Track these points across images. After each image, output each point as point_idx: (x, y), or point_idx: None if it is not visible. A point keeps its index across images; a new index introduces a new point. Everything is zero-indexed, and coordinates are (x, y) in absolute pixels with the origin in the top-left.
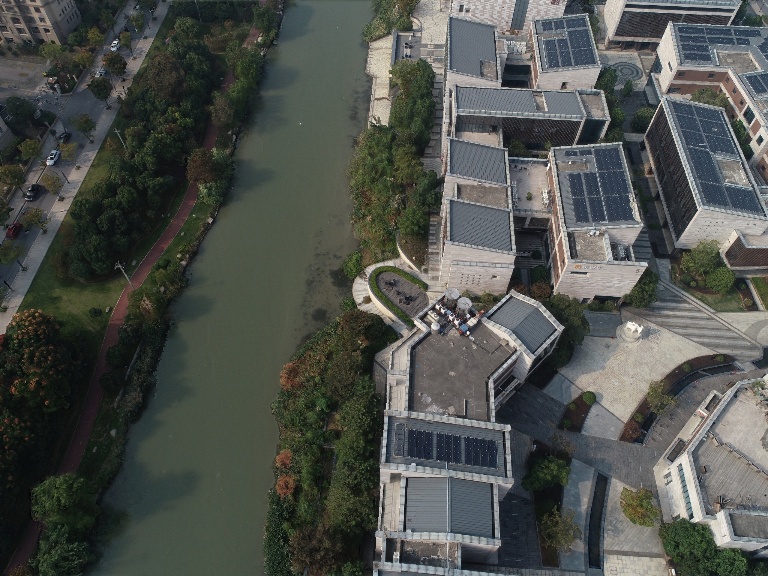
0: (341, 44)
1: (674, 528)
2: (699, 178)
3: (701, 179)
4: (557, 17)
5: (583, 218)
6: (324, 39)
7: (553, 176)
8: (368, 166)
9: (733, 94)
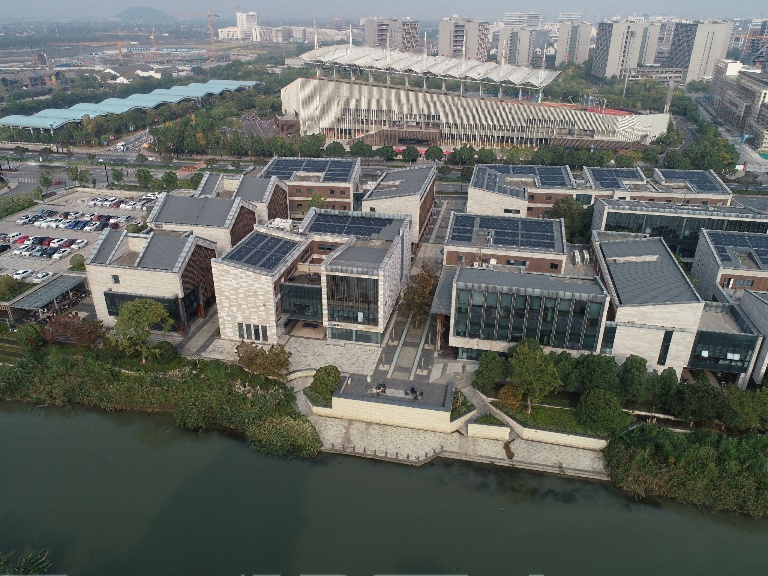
0: (301, 498)
1: None
2: None
3: None
4: (449, 228)
5: None
6: (275, 525)
7: (765, 275)
8: (767, 460)
9: (549, 200)
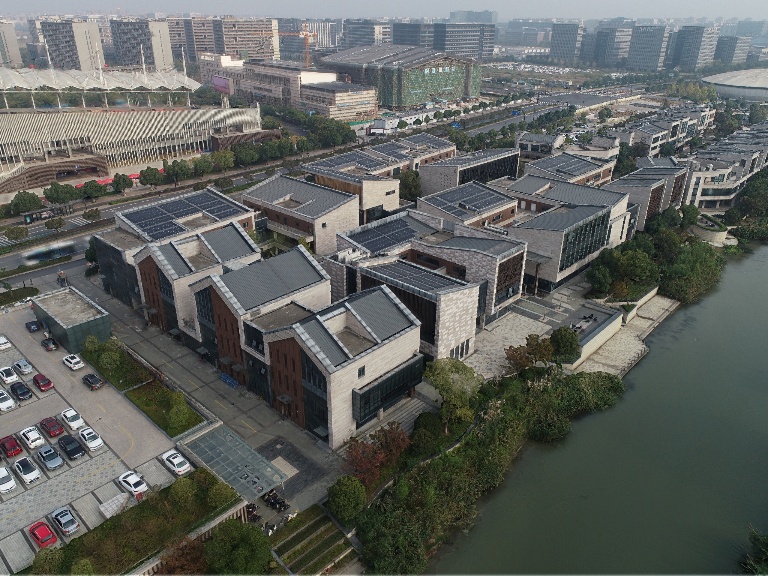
0: None
1: (625, 158)
2: (500, 153)
3: (500, 153)
4: None
5: (587, 164)
6: (698, 421)
7: None
8: None
9: None
